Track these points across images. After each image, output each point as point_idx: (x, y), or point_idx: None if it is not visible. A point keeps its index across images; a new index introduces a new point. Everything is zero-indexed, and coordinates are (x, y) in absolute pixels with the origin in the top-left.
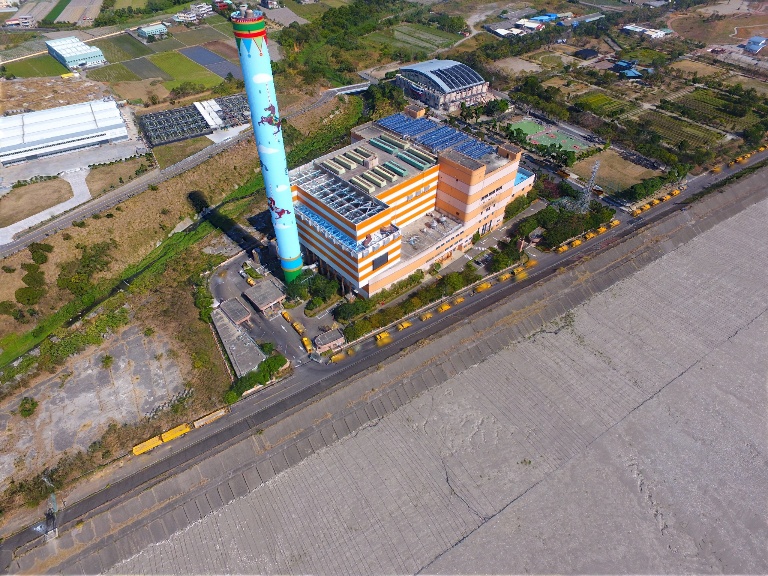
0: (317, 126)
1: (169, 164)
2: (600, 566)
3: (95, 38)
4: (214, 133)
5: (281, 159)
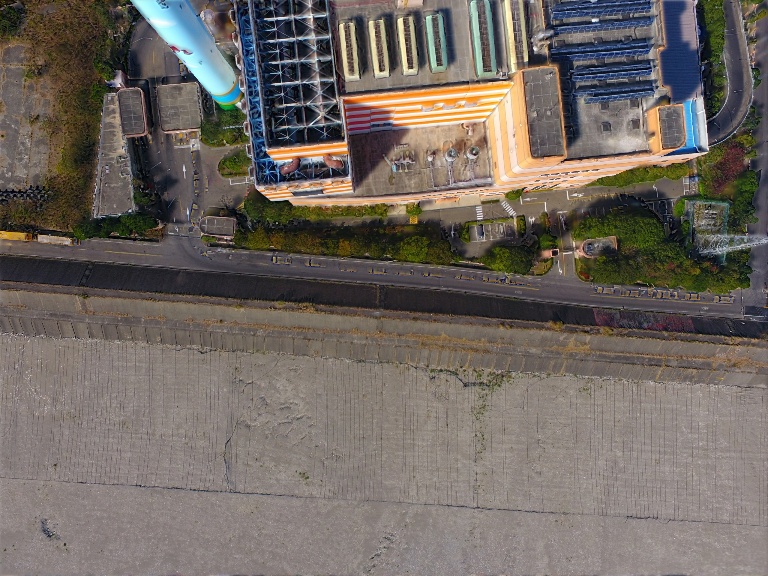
0: None
1: None
2: (284, 574)
3: None
4: None
5: None
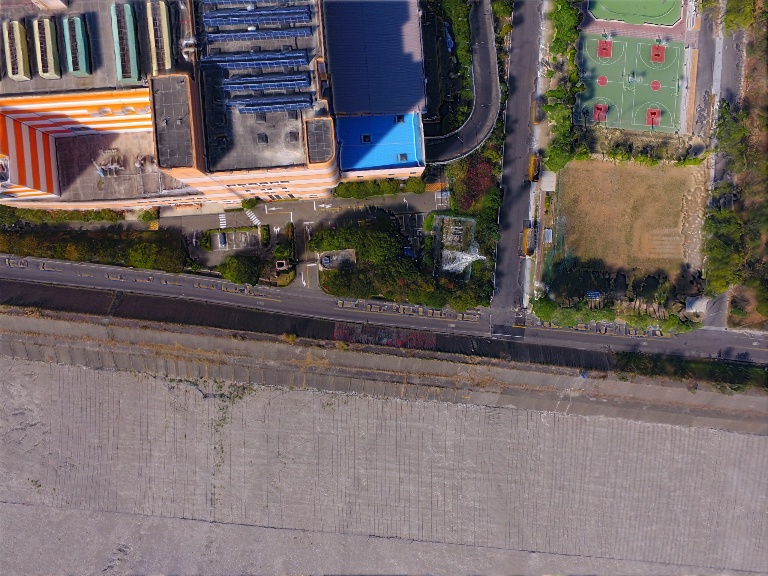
0: None
1: None
2: None
3: None
4: None
5: None
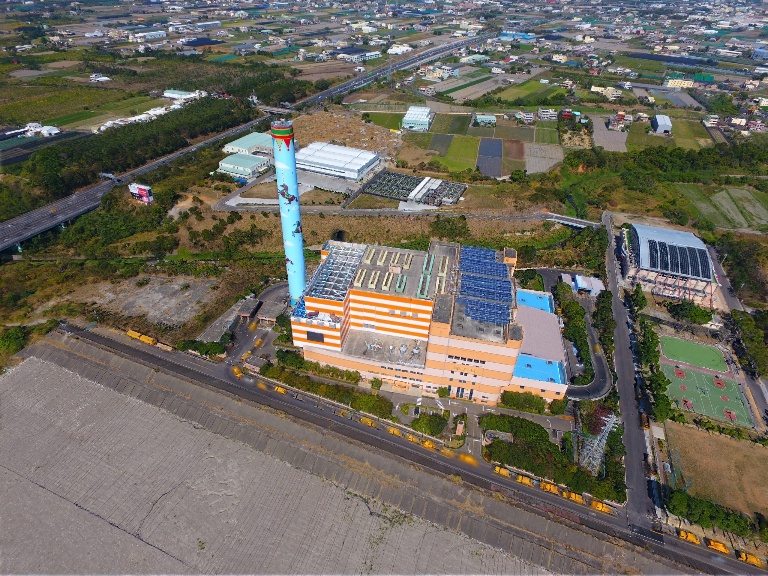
0: (493, 235)
1: (354, 207)
2: None
3: (447, 113)
4: (408, 202)
5: (290, 223)
